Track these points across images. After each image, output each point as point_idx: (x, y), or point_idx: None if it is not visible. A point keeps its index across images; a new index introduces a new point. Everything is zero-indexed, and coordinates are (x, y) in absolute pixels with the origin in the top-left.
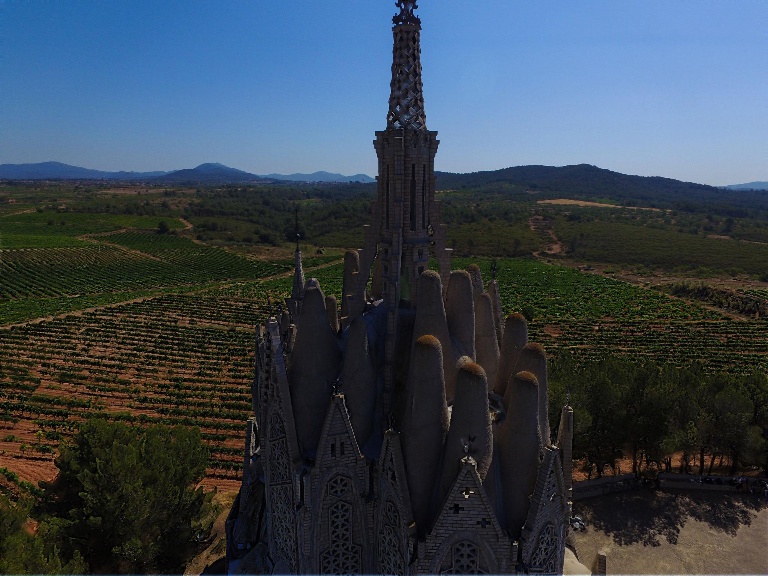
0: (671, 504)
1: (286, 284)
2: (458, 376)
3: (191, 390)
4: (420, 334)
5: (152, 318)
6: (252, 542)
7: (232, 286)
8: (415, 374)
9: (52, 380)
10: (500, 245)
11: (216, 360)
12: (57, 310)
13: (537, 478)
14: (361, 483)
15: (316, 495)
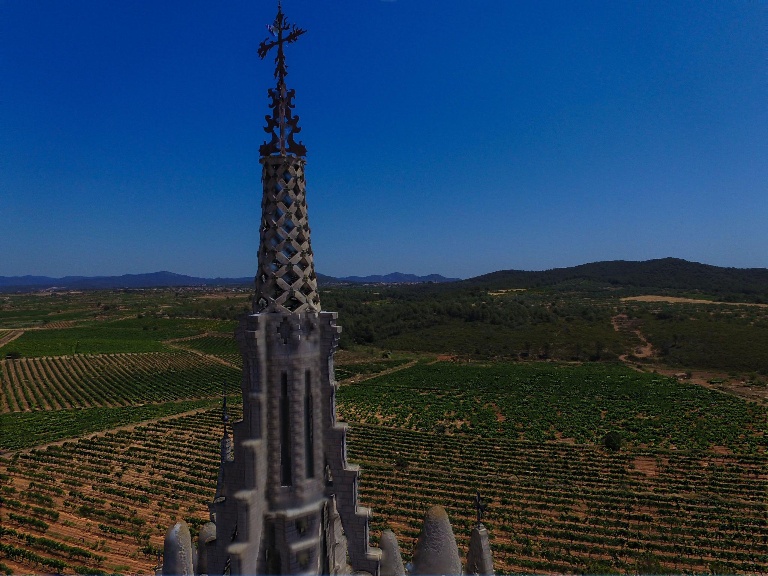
0: None
1: (344, 394)
2: None
3: None
4: None
5: (197, 435)
6: None
7: None
8: None
9: (72, 513)
10: (579, 349)
11: None
12: (117, 422)
13: None
14: None
15: None
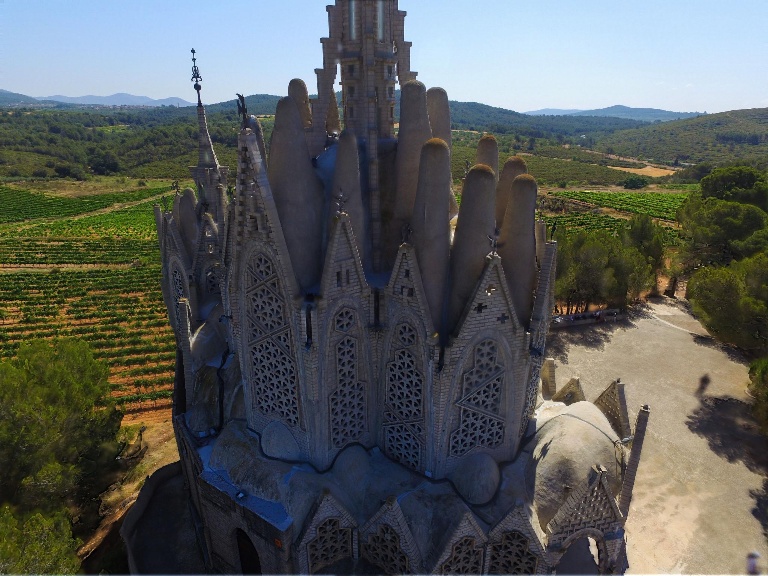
0: (556, 339)
1: (110, 219)
2: (469, 179)
3: (22, 339)
4: (408, 153)
5: None
6: (215, 427)
7: (35, 226)
8: (427, 180)
9: None
10: None
11: (45, 305)
12: None
13: (540, 273)
14: (365, 315)
15: (323, 332)
